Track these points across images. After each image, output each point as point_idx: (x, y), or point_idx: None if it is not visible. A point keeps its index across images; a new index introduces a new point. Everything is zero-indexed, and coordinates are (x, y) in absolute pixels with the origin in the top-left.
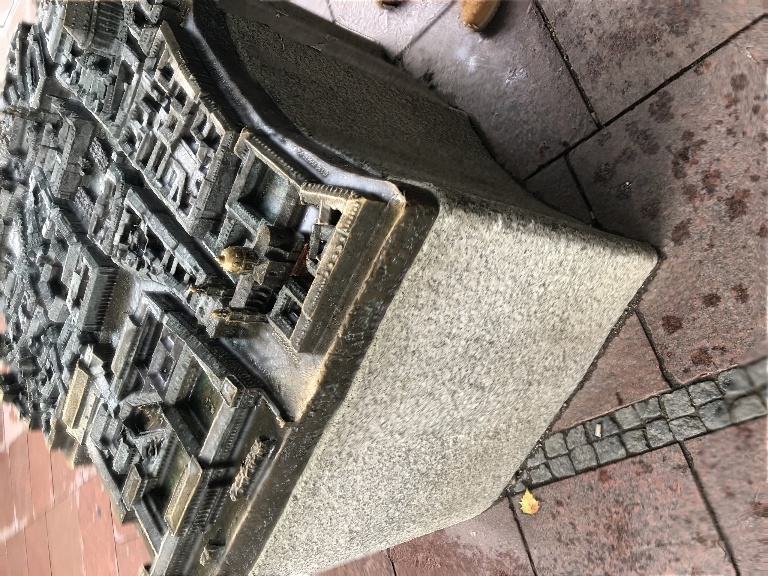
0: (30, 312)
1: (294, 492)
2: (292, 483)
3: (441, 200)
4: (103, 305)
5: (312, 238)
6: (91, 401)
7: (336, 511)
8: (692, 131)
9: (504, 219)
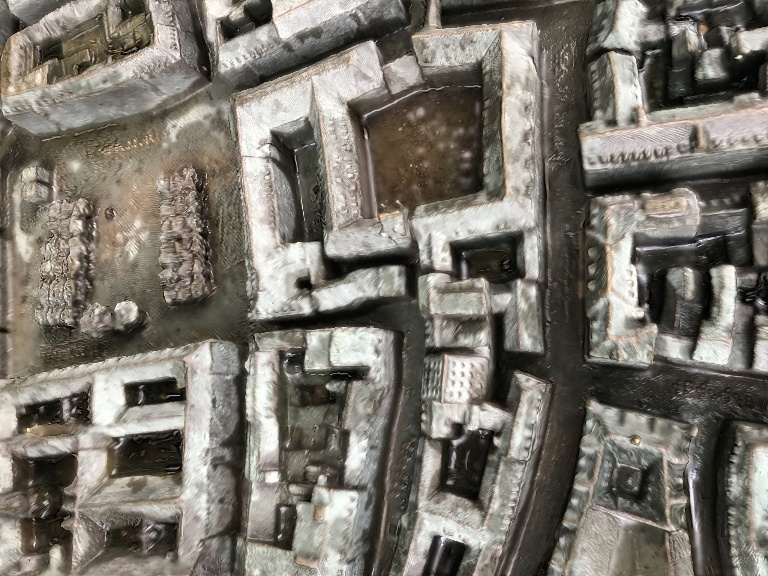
0: None
1: None
2: None
3: None
4: None
5: None
6: None
7: None
8: None
9: None
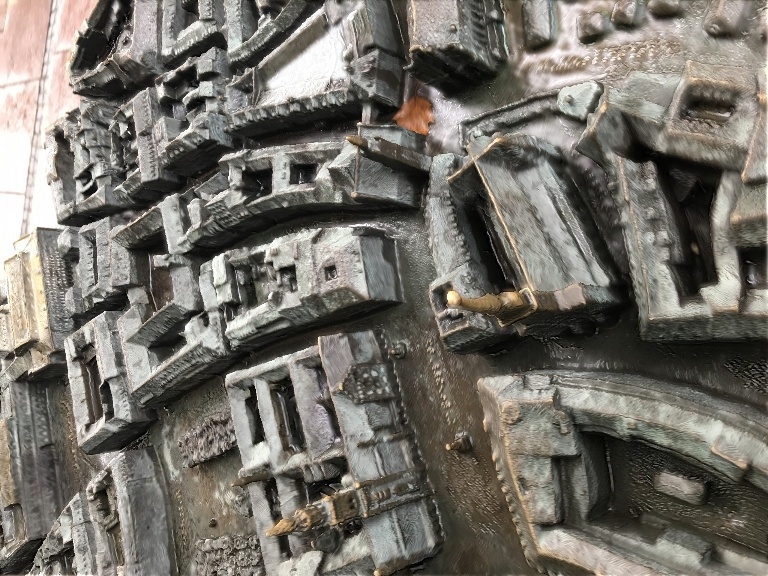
0: (187, 85)
1: None
2: None
3: None
4: None
5: None
6: None
7: None
8: None
9: None
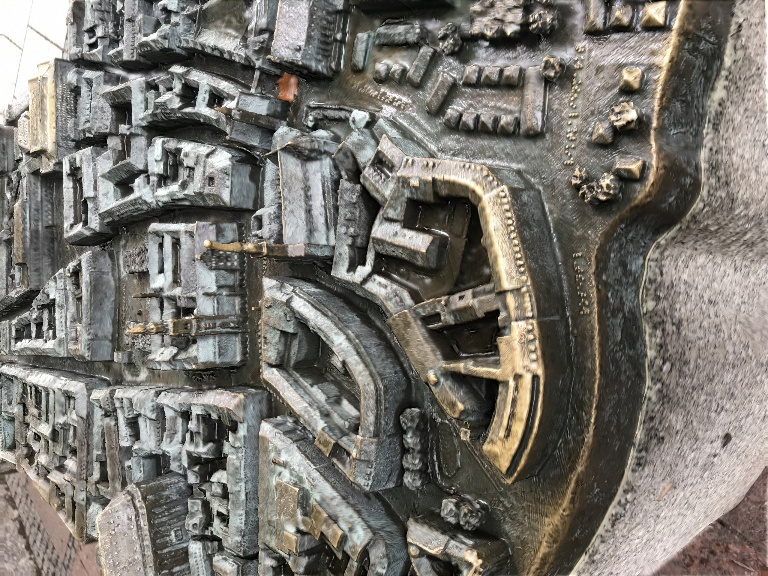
0: None
1: None
2: None
3: None
4: None
5: None
6: None
7: None
8: None
9: None
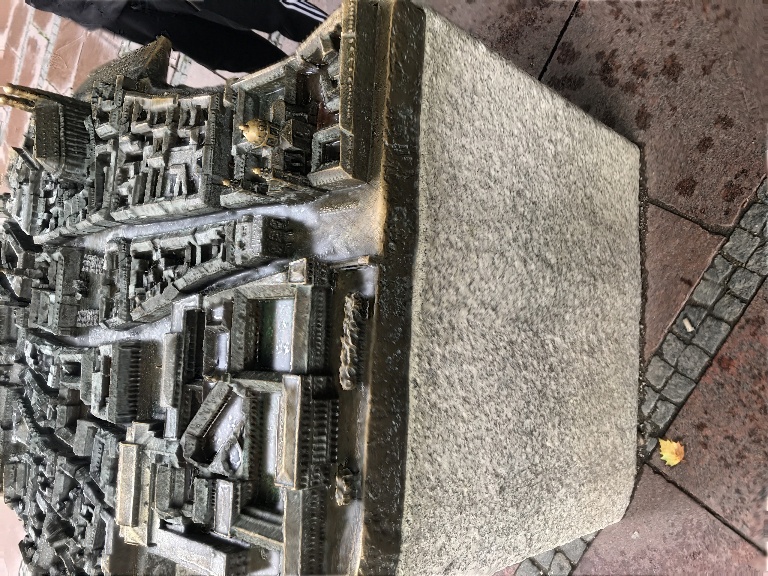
0: None
1: (411, 375)
2: (404, 360)
3: (422, 6)
4: (132, 388)
5: (323, 84)
6: (146, 479)
7: (468, 426)
8: (601, 51)
9: (485, 45)
